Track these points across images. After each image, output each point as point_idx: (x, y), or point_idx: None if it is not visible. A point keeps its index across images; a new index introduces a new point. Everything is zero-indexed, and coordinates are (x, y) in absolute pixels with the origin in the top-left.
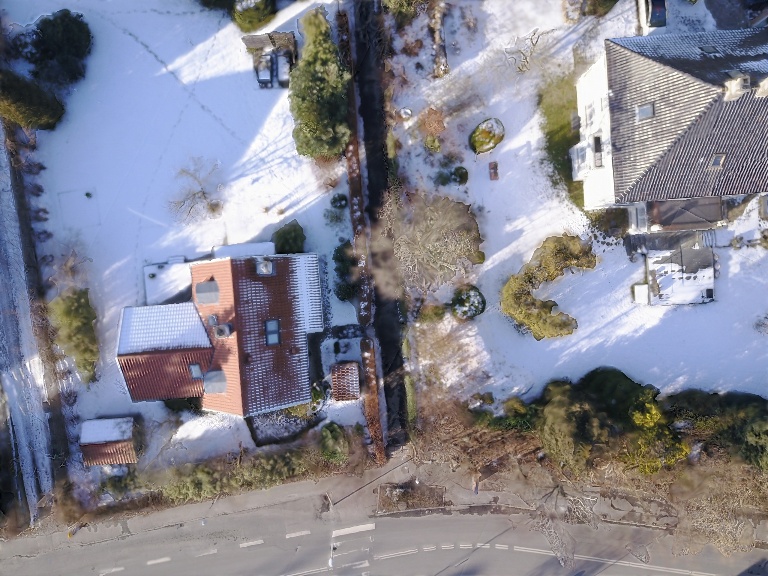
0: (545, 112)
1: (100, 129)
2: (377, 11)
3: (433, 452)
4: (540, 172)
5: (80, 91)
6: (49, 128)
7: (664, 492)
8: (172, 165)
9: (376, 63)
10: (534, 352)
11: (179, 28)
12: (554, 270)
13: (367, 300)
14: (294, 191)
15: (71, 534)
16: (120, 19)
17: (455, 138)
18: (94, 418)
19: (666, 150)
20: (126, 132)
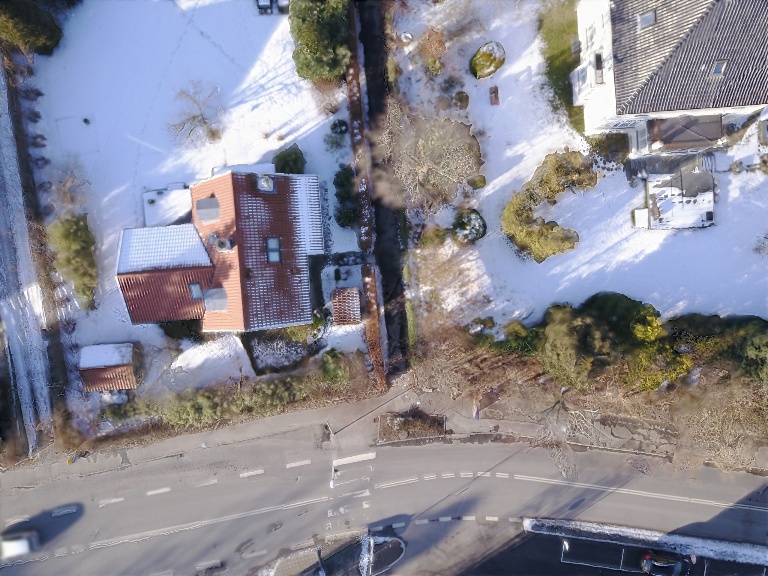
0: (546, 37)
1: (98, 55)
2: None
3: (434, 380)
4: (541, 97)
5: (78, 17)
6: (47, 54)
7: (664, 412)
8: None
9: None
10: (535, 277)
11: None
12: (555, 185)
13: (368, 224)
14: (294, 117)
15: (70, 461)
16: None
17: (456, 63)
18: (93, 345)
19: (668, 56)
20: (125, 58)
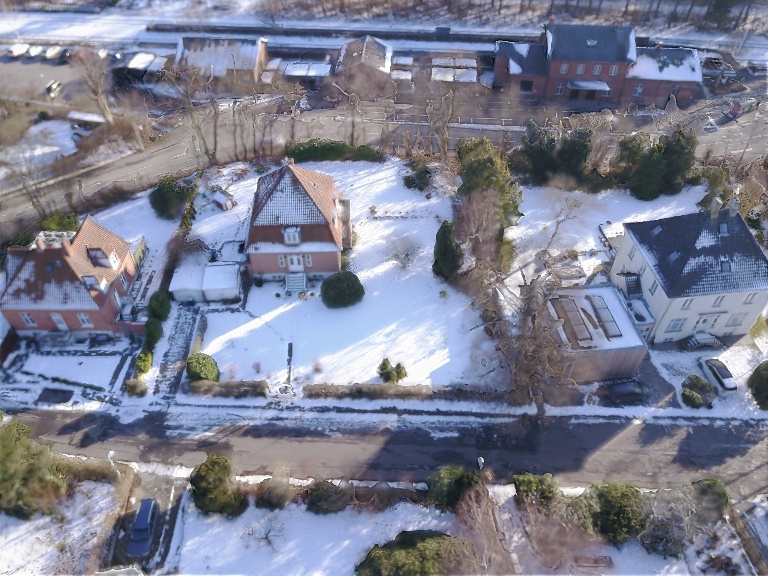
0: (760, 316)
1: None
2: None
3: None
4: None
5: None
6: None
7: None
8: None
9: None
10: None
11: None
12: None
13: None
14: None
15: None
16: None
17: None
18: None
19: None
20: None
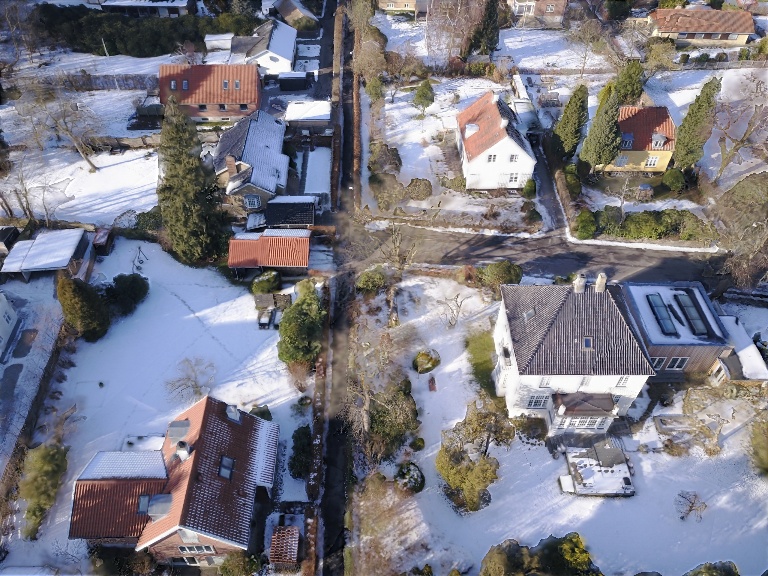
0: (471, 352)
1: (130, 345)
2: (351, 293)
3: None
4: (470, 389)
5: (126, 323)
6: (92, 342)
7: None
8: None
9: (347, 319)
10: (473, 533)
11: (211, 294)
12: (477, 425)
13: (317, 472)
14: (270, 393)
15: None
16: (172, 287)
17: (402, 363)
18: None
19: (547, 330)
20: (149, 348)
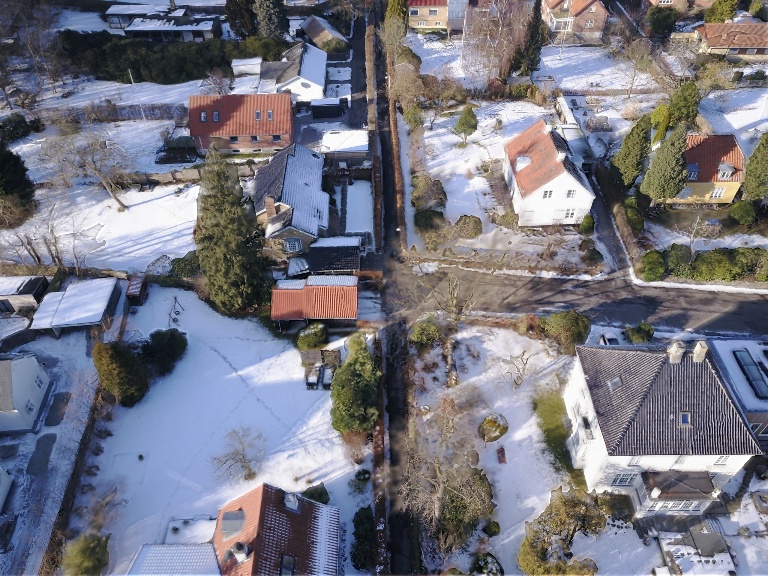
0: (541, 415)
1: (170, 410)
2: (404, 346)
3: None
4: (543, 460)
5: (164, 383)
6: (129, 406)
7: None
8: (221, 439)
9: (401, 377)
10: None
11: (253, 349)
12: (565, 516)
13: (383, 564)
14: (323, 465)
15: None
16: (211, 341)
17: (466, 429)
18: None
19: (639, 405)
20: (190, 413)
